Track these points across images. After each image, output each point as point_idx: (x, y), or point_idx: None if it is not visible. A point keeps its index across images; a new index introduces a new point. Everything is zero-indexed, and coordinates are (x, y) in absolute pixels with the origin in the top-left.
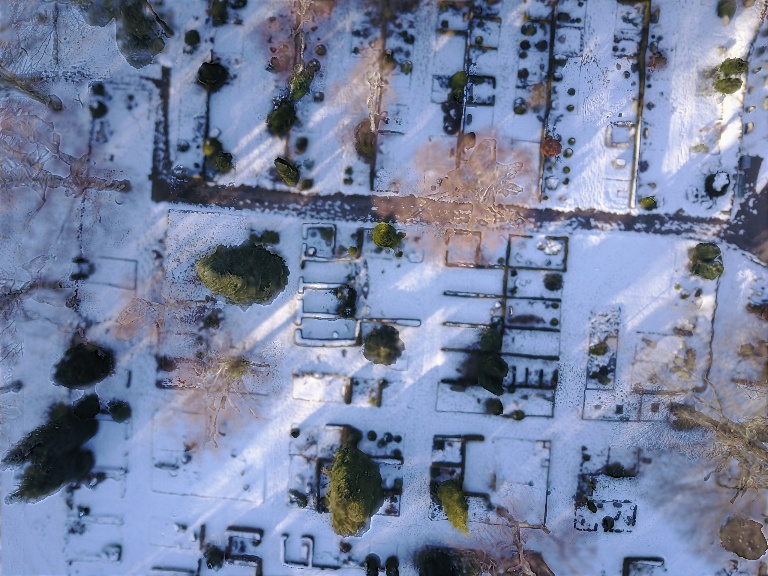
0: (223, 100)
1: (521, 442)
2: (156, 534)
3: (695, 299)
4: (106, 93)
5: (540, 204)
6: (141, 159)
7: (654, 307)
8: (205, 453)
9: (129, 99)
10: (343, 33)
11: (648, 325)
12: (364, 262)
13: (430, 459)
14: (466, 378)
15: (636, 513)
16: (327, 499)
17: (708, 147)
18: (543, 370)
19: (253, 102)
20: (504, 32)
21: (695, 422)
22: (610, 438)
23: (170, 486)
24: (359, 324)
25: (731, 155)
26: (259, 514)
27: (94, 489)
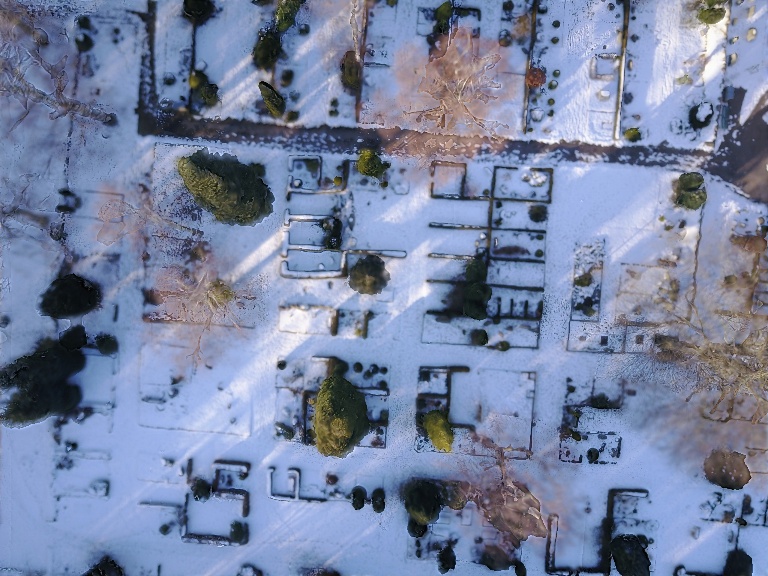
0: (209, 33)
1: (506, 373)
2: (143, 469)
3: (679, 230)
4: (92, 27)
5: (525, 136)
6: (127, 93)
7: (638, 239)
8: (192, 387)
9: (115, 33)
10: None
11: (632, 257)
12: (350, 194)
13: (416, 391)
14: (451, 309)
15: (621, 445)
16: (313, 431)
17: (692, 79)
18: (528, 301)
19: (239, 35)
20: None
21: (679, 354)
22: (595, 370)
23: (157, 420)
24: (345, 255)
25: (715, 86)
26: (246, 447)
27: (81, 424)
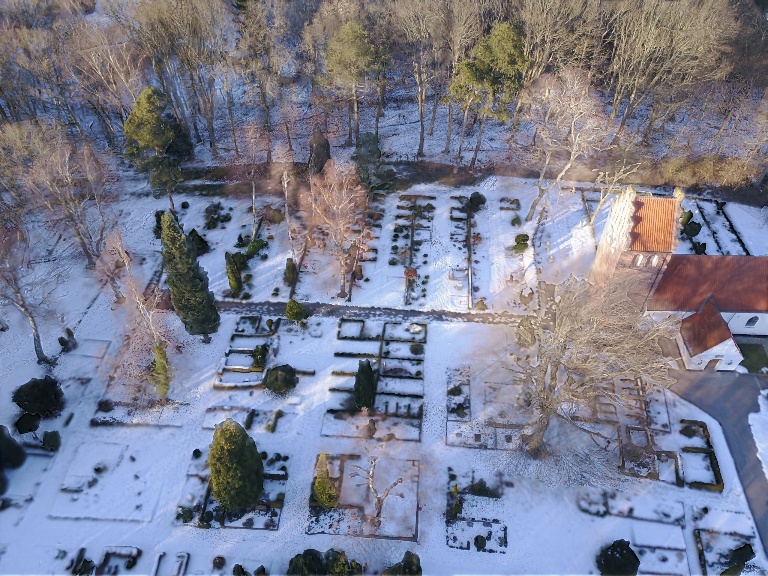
0: (203, 260)
1: (393, 461)
2: (33, 563)
3: None
4: None
5: (406, 307)
6: None
7: (496, 367)
8: (112, 477)
9: (143, 260)
10: (285, 231)
11: (493, 378)
12: (278, 336)
13: (312, 476)
14: (347, 409)
15: (506, 534)
16: (212, 513)
17: (518, 280)
18: (410, 404)
19: (222, 260)
20: (383, 231)
21: (546, 451)
22: (473, 463)
23: (68, 511)
24: (266, 370)
25: (533, 282)
26: (143, 534)
27: None
